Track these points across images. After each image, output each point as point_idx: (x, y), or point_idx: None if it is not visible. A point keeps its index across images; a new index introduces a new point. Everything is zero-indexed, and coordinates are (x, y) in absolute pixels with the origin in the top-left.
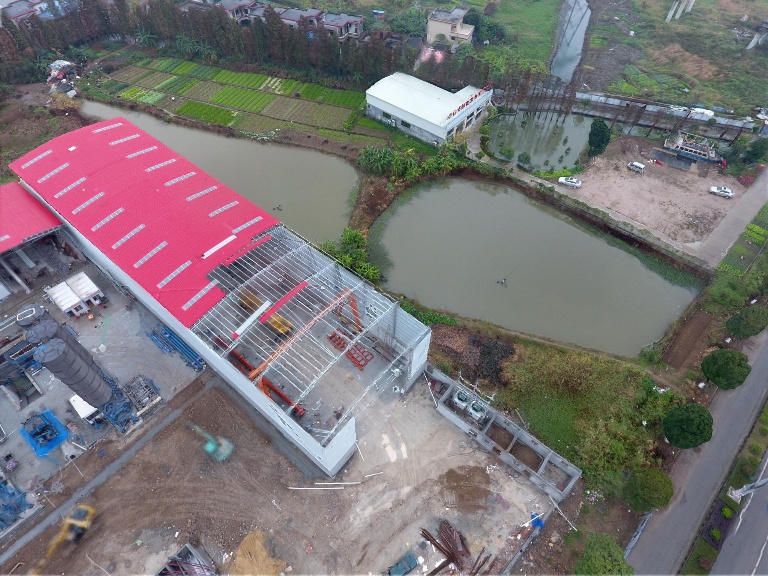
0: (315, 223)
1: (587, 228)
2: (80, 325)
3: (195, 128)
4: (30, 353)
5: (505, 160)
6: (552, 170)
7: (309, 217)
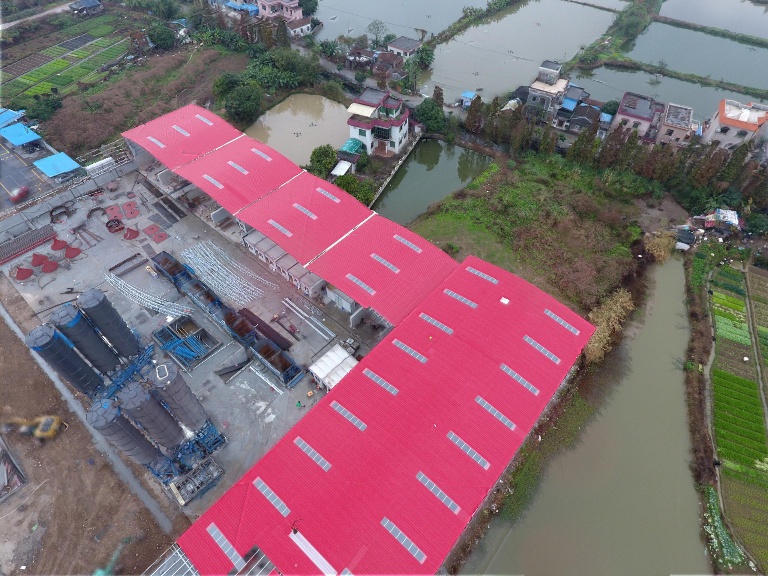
0: None
1: None
2: (304, 386)
3: (688, 410)
4: None
5: None
6: None
7: None
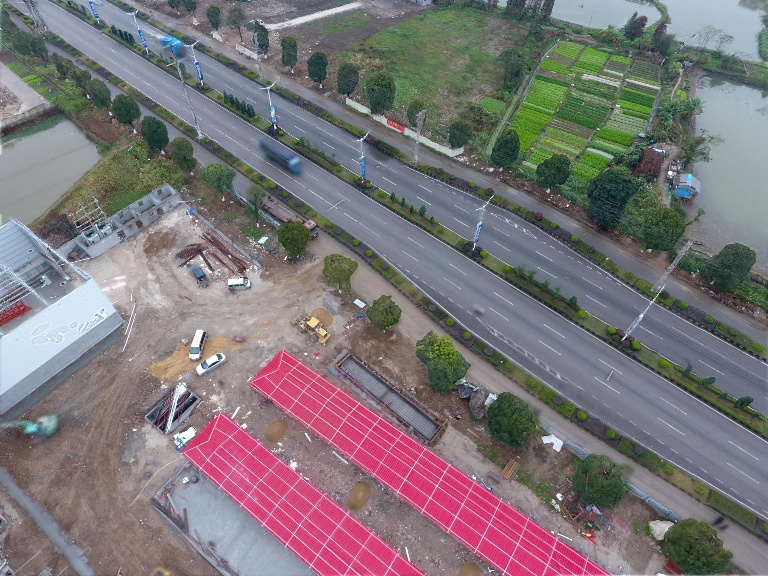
0: None
1: None
2: None
3: None
4: None
5: None
6: None
7: None
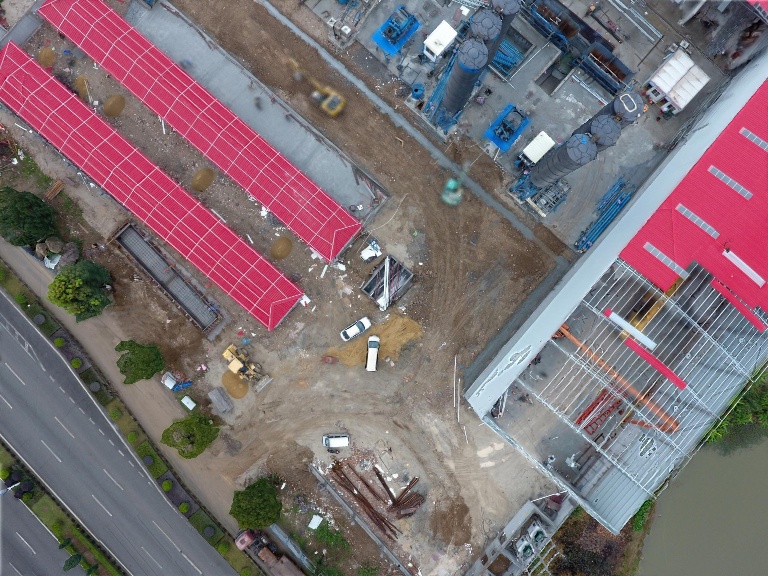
0: None
1: None
2: None
3: None
4: (597, 67)
5: None
6: None
7: None
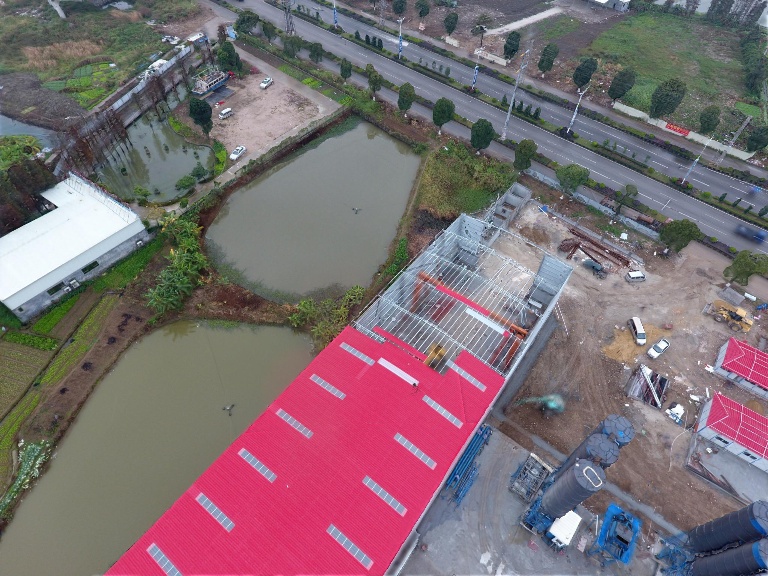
0: (264, 361)
1: (295, 156)
2: None
3: None
4: None
5: (191, 190)
6: (218, 160)
7: (252, 370)
